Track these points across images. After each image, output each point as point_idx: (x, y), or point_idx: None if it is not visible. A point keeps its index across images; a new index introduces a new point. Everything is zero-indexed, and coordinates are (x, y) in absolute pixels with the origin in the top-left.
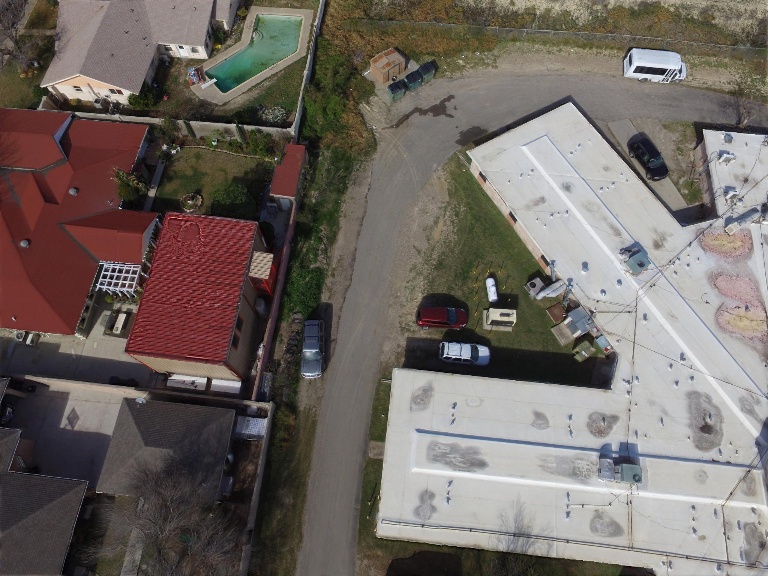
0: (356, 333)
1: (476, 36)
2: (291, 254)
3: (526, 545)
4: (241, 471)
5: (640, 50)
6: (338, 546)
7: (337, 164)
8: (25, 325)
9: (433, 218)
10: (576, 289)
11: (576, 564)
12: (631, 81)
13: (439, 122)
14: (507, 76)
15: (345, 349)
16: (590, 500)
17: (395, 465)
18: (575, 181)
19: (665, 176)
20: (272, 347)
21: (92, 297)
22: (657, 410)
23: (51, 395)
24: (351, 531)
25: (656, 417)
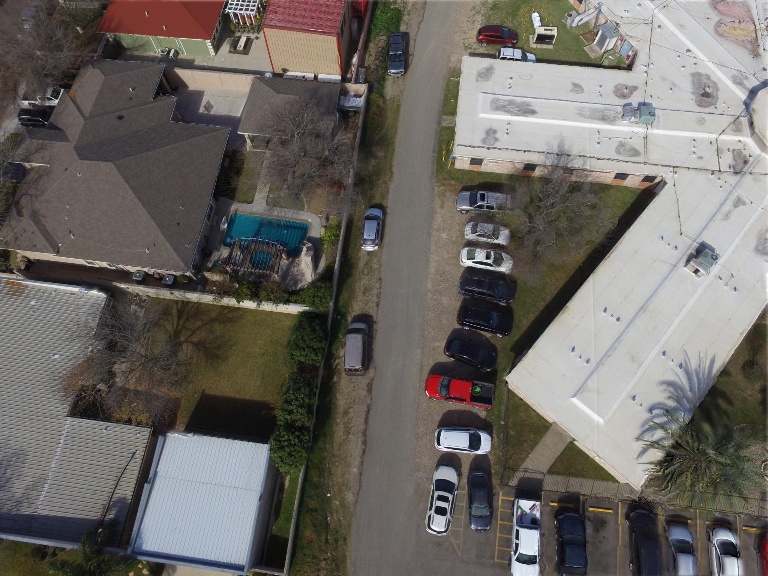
0: (429, 50)
1: None
2: None
3: (567, 160)
4: None
5: None
6: (421, 178)
7: None
8: (173, 33)
9: None
10: (605, 9)
11: (603, 191)
12: None
13: None
14: None
15: (421, 60)
16: (615, 135)
17: (466, 113)
18: None
19: None
20: (363, 59)
21: (220, 24)
22: (668, 83)
23: (190, 92)
24: (430, 169)
25: (667, 87)
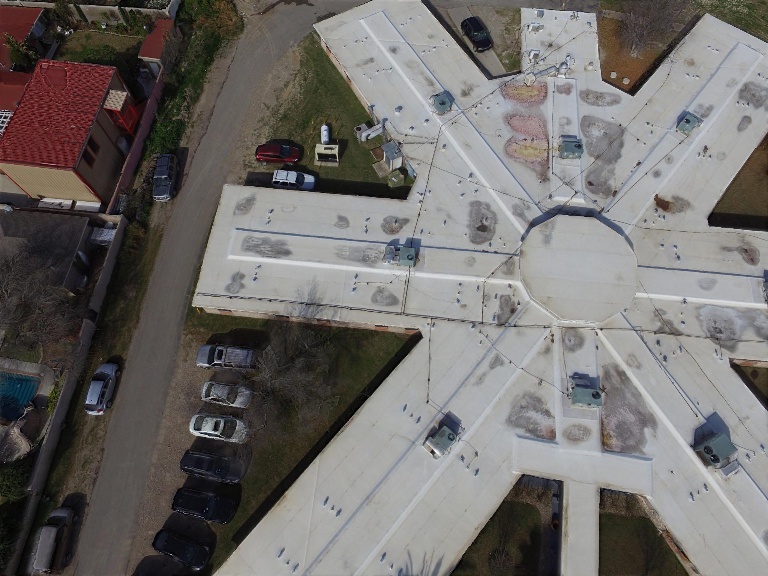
0: (205, 169)
1: None
2: (158, 110)
3: (315, 311)
4: (96, 274)
5: None
6: (168, 325)
7: (206, 41)
8: None
9: (284, 82)
10: (389, 126)
11: (367, 338)
12: None
13: (301, 9)
14: None
15: (194, 181)
16: (374, 279)
17: (214, 254)
18: (401, 45)
19: (488, 48)
20: (132, 180)
21: None
22: (442, 214)
23: None
24: (180, 313)
25: (440, 219)
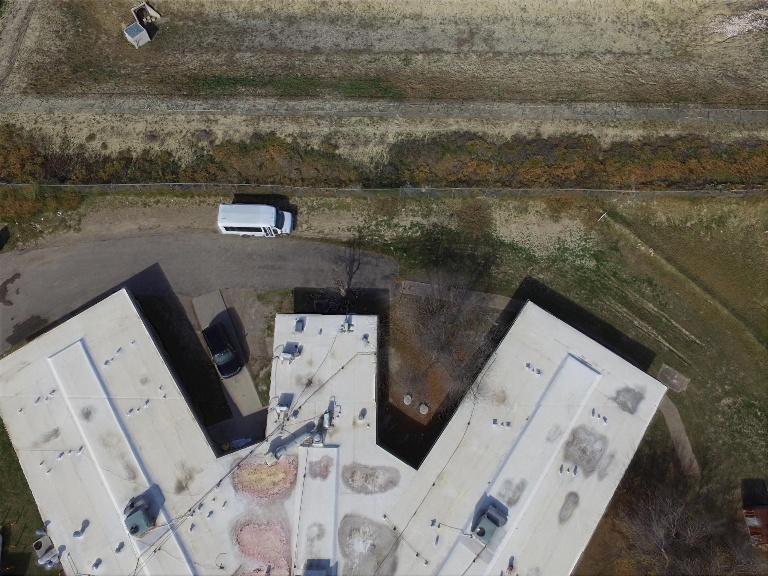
0: None
1: (54, 194)
2: None
3: None
4: None
5: (226, 207)
6: None
7: None
8: None
9: None
10: (66, 561)
11: None
12: (234, 237)
13: None
14: (89, 241)
15: None
16: None
17: None
18: (98, 404)
19: (236, 372)
20: None
21: None
22: None
23: None
24: None
25: None
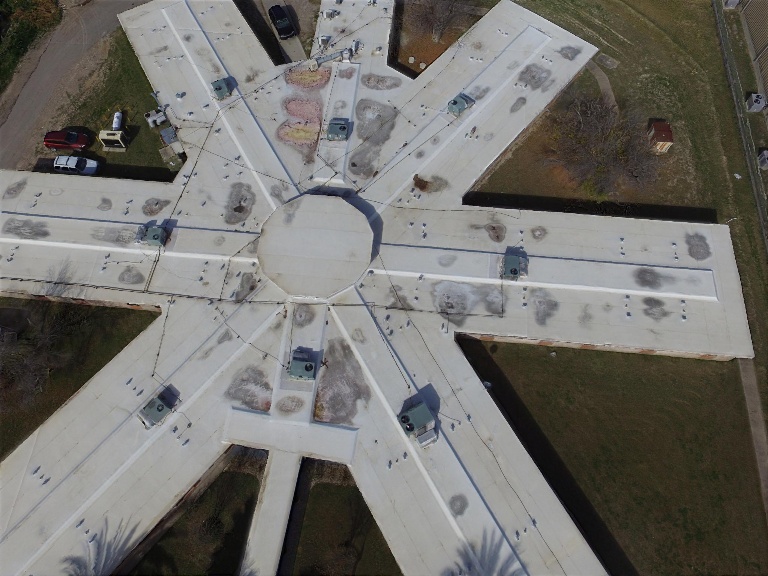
0: None
1: None
2: None
3: (62, 290)
4: None
5: None
6: None
7: (22, 33)
8: None
9: (89, 71)
10: (169, 112)
11: (123, 316)
12: None
13: (120, 1)
14: None
15: None
16: (125, 259)
17: None
18: (196, 33)
19: (290, 35)
20: None
21: None
22: (203, 196)
23: None
24: None
25: (200, 201)
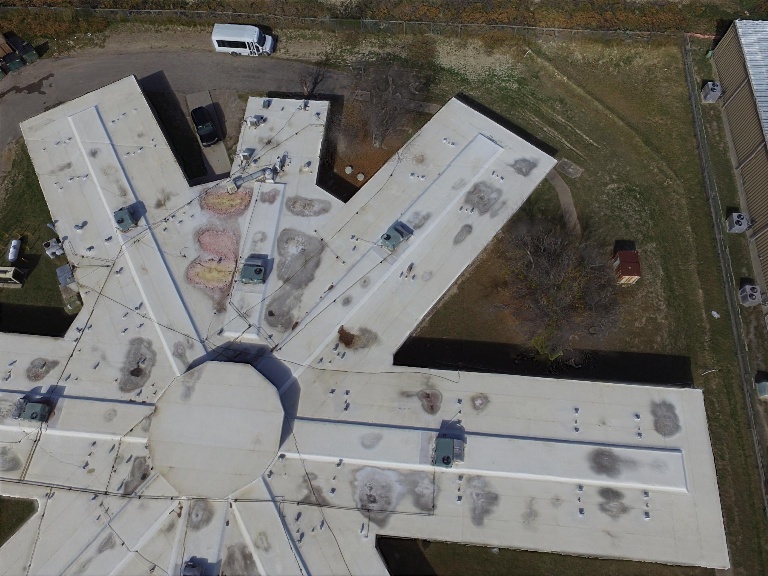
0: None
1: (87, 18)
2: None
3: None
4: None
5: (219, 25)
6: None
7: None
8: None
9: None
10: (67, 246)
11: (3, 500)
12: (225, 55)
13: (30, 99)
14: (111, 54)
15: None
16: (1, 437)
17: None
18: (104, 147)
19: (213, 142)
20: None
21: None
22: (97, 355)
23: None
24: None
25: (93, 361)
